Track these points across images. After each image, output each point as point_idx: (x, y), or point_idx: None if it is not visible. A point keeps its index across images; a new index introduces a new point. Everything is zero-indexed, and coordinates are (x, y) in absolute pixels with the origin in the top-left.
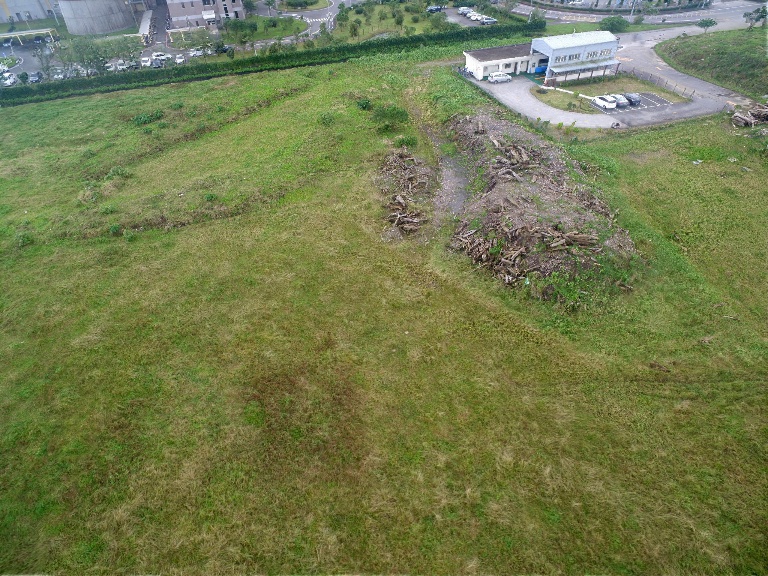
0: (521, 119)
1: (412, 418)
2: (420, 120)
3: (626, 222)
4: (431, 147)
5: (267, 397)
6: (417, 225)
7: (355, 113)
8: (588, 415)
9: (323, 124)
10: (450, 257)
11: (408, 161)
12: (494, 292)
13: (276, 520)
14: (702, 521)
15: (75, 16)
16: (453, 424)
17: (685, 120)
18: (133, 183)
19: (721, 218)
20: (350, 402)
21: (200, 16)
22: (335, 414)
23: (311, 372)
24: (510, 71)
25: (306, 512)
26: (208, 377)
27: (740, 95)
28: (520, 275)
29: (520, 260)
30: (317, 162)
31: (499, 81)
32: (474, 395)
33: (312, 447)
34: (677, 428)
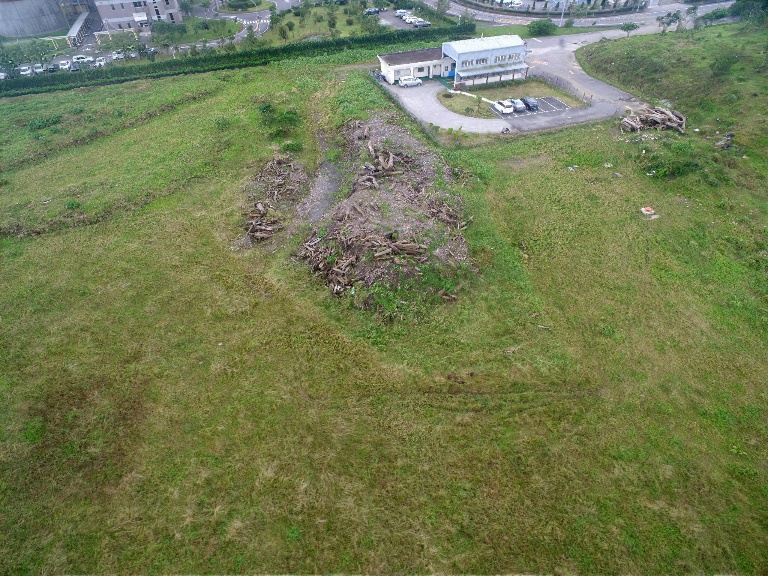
0: (416, 124)
1: (191, 433)
2: (317, 125)
3: (477, 229)
4: (317, 153)
5: (53, 412)
6: (270, 233)
7: (253, 118)
8: (368, 428)
9: (218, 129)
10: (290, 266)
11: (285, 167)
12: (319, 302)
13: (14, 541)
14: (438, 537)
15: (4, 18)
16: (230, 439)
17: (576, 125)
18: (5, 190)
19: (574, 225)
20: (136, 417)
21: (132, 18)
22: (115, 429)
23: (108, 386)
24: (424, 75)
25: (48, 532)
26: (3, 392)
27: (639, 100)
28: (348, 285)
29: (350, 269)
30: (195, 168)
31: (409, 85)
32: (262, 409)
33: (78, 464)
34: (450, 441)
